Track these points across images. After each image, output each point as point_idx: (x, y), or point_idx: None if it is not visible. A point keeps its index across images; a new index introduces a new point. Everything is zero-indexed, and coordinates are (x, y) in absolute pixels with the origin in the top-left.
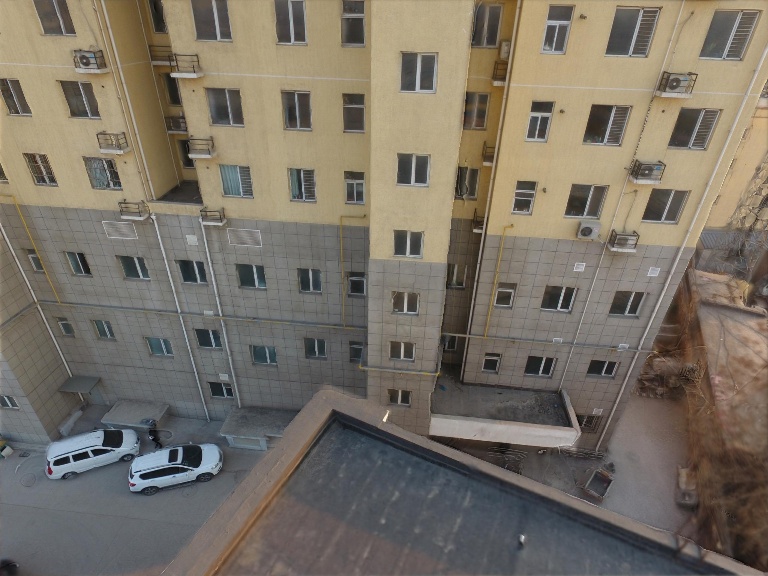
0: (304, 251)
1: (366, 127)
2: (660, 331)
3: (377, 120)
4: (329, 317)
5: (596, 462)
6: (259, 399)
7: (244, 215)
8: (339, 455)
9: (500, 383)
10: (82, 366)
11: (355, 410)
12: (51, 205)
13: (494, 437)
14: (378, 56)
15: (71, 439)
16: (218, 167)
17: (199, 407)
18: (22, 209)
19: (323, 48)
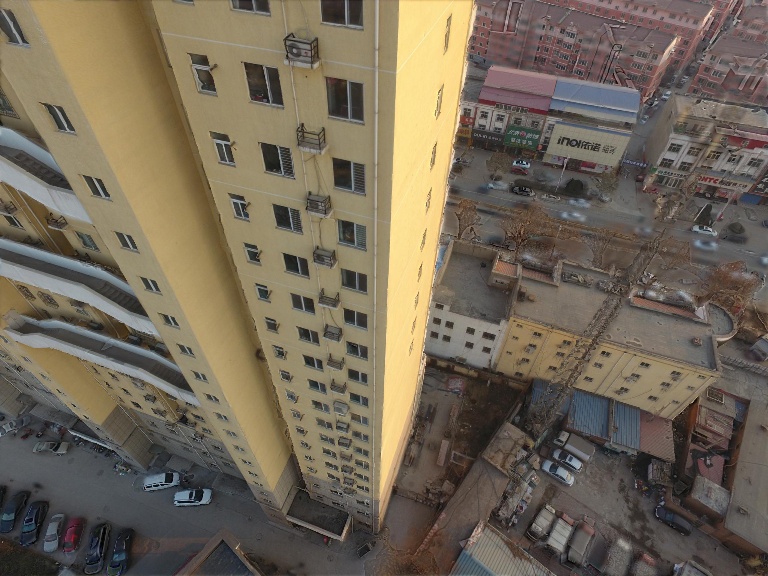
0: None
1: None
2: (464, 460)
3: (238, 464)
4: None
5: (371, 538)
6: (230, 473)
7: (211, 437)
8: (221, 555)
9: (325, 503)
10: (157, 442)
11: (229, 542)
12: None
13: (312, 529)
14: (233, 456)
15: (153, 477)
16: None
17: None
18: (130, 410)
19: None
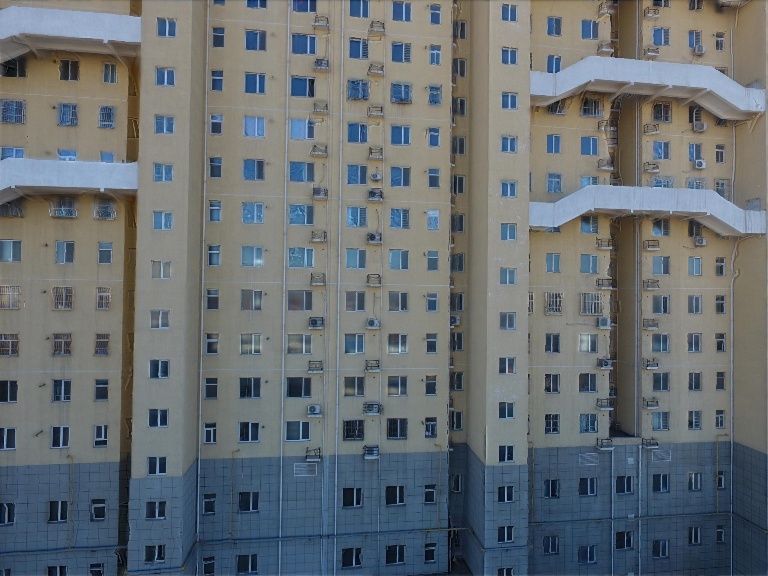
0: (693, 461)
1: (727, 387)
2: None
3: None
4: (705, 508)
5: None
6: None
7: (663, 441)
8: None
9: None
10: None
11: None
12: (550, 446)
13: None
14: None
15: None
16: (651, 414)
17: None
18: None
19: (709, 353)
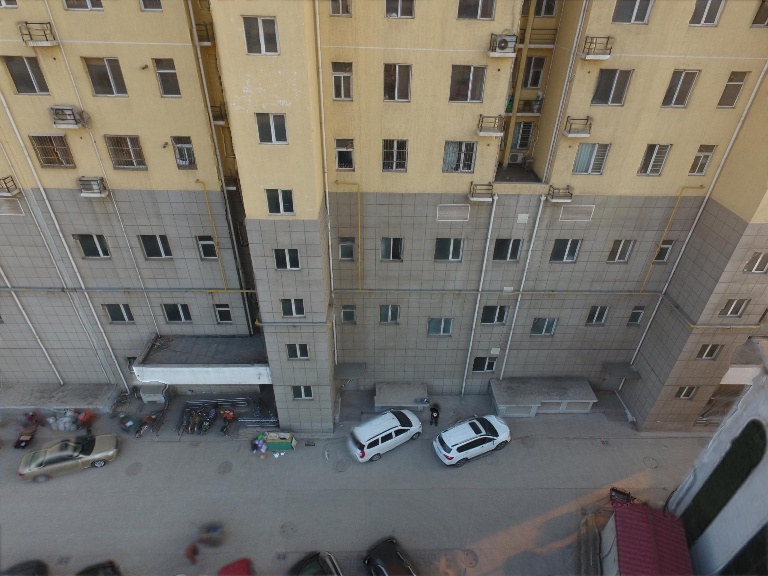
0: (628, 223)
1: (740, 102)
2: None
3: None
4: (625, 284)
5: None
6: (521, 370)
7: (586, 191)
8: None
9: (757, 334)
10: (350, 353)
11: None
12: (391, 191)
13: None
14: None
15: (369, 423)
16: (577, 146)
17: (456, 383)
18: (361, 197)
19: (732, 29)
